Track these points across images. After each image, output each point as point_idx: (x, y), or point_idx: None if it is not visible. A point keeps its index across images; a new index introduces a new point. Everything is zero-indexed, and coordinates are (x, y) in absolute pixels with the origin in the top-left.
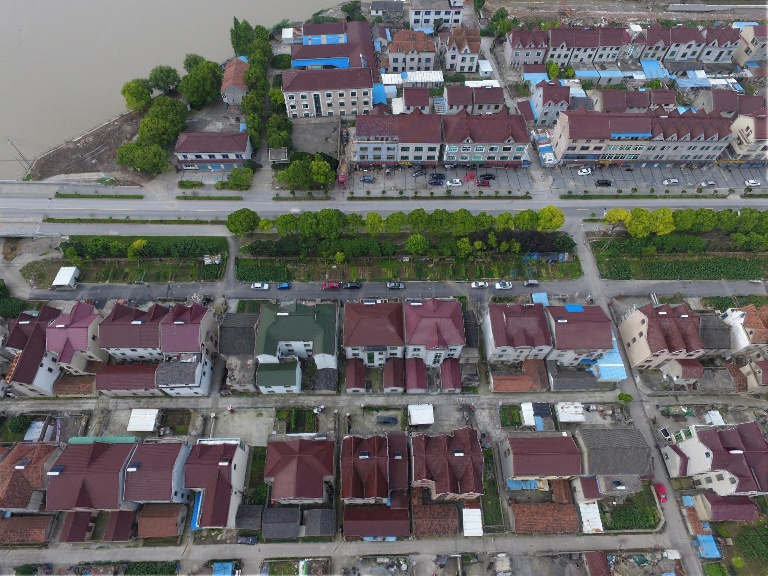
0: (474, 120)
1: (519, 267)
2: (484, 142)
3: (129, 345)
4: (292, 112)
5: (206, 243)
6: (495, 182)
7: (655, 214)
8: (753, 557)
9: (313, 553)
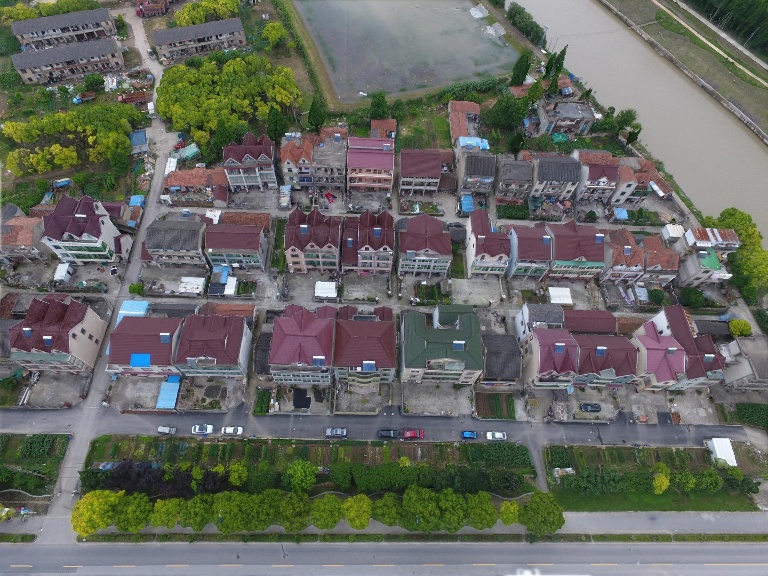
0: None
1: (171, 458)
2: None
3: (600, 337)
4: None
5: (580, 492)
6: None
7: None
8: (107, 198)
9: (411, 217)
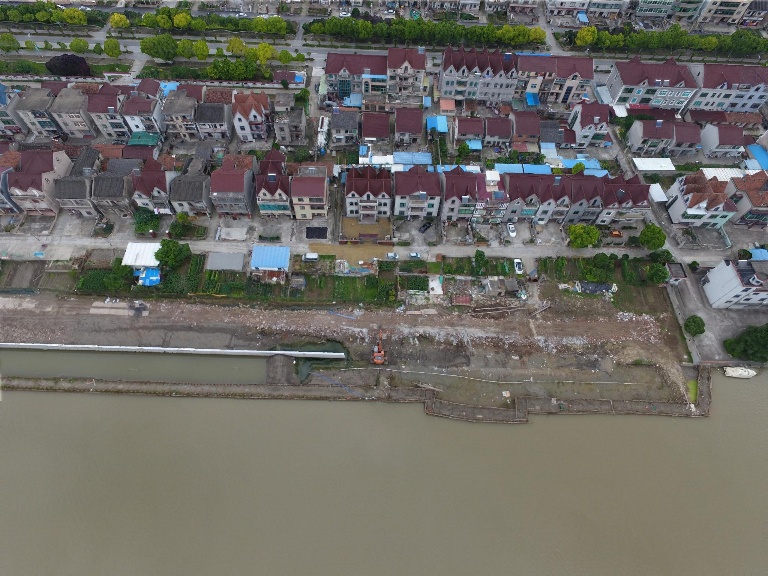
0: (673, 66)
1: None
2: None
3: None
4: None
5: None
6: None
7: (513, 32)
8: None
9: None
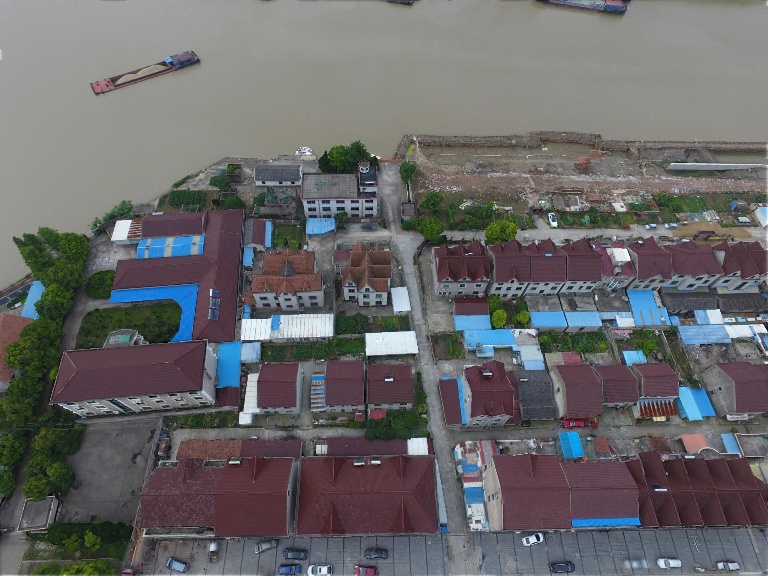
0: (344, 495)
1: None
2: (361, 531)
3: None
4: (82, 412)
5: None
6: (388, 564)
7: None
8: None
9: None
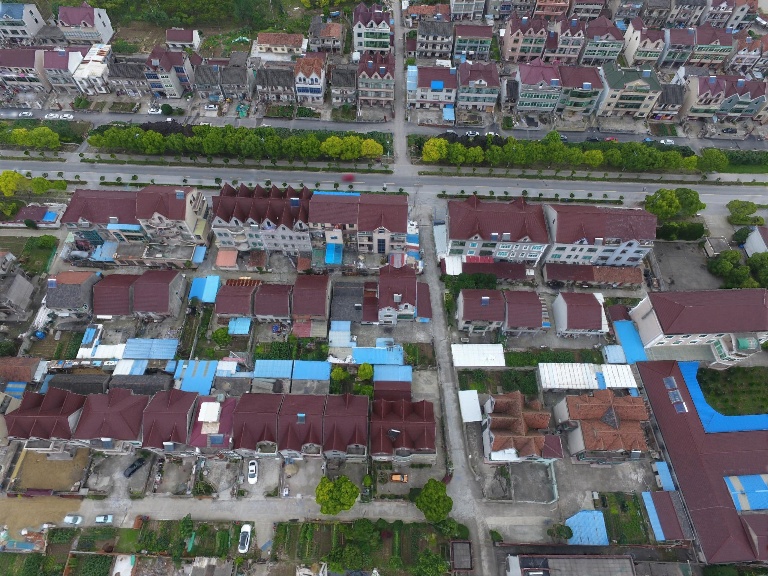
0: None
1: None
2: None
3: None
4: None
5: (733, 161)
6: None
7: (339, 146)
8: None
9: None
